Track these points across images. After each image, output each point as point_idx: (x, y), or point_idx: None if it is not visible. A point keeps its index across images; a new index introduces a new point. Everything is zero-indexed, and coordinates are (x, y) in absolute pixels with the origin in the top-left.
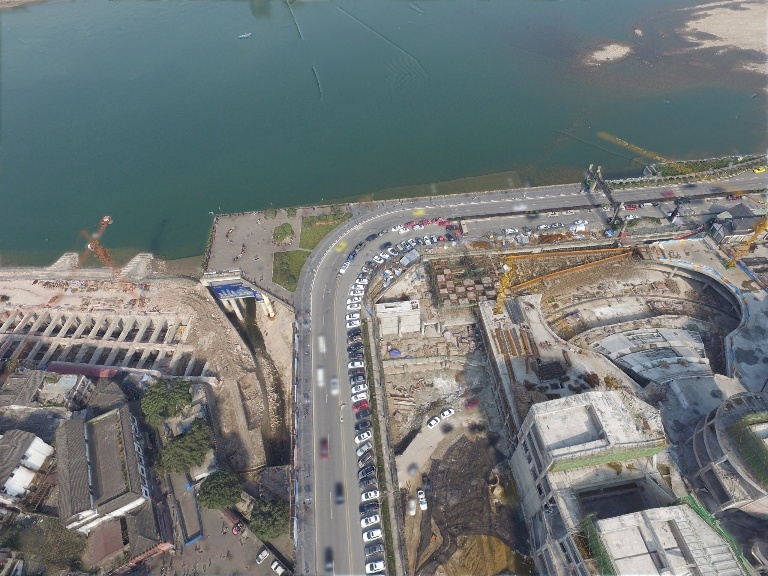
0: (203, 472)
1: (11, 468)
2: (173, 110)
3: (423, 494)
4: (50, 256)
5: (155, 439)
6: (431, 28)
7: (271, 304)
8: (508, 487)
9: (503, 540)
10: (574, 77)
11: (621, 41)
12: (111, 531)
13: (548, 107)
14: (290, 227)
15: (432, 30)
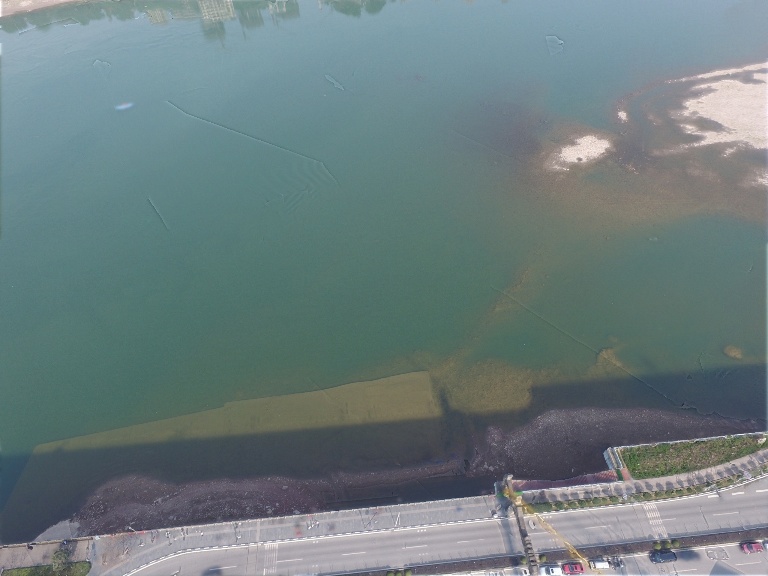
0: None
1: None
2: None
3: None
4: None
5: None
6: (361, 100)
7: None
8: None
9: None
10: (532, 190)
11: (599, 130)
12: None
13: (491, 243)
14: None
15: (362, 103)
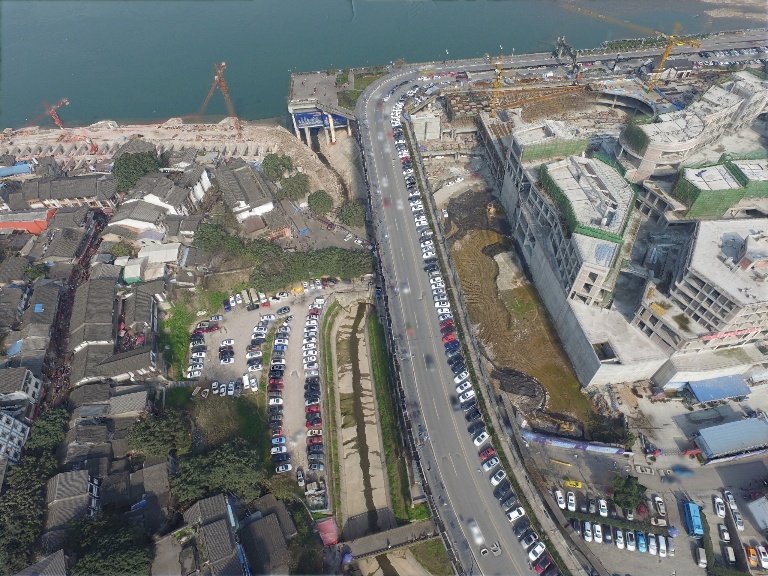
0: (305, 201)
1: (196, 180)
2: (232, 33)
3: (445, 210)
4: (160, 121)
5: (270, 190)
6: None
7: (334, 130)
8: (499, 210)
9: (496, 231)
10: (555, 6)
11: None
12: (256, 220)
13: (533, 26)
14: (347, 75)
15: None
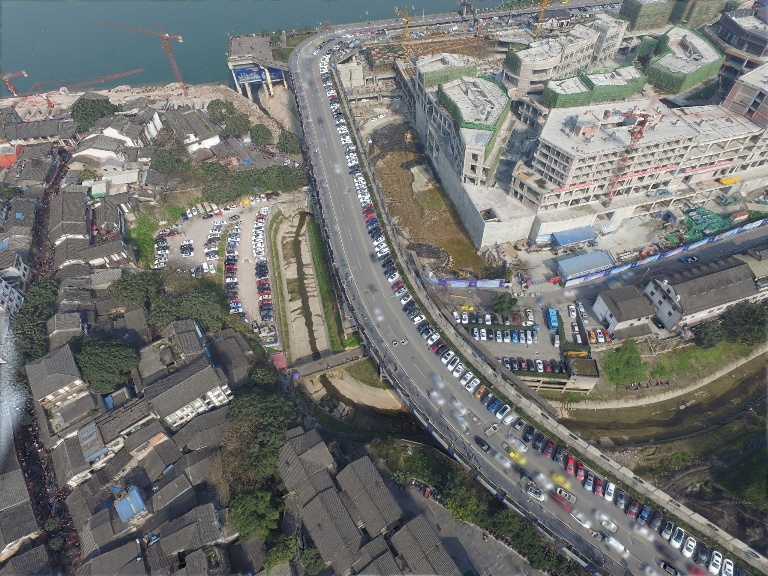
0: (248, 137)
1: (148, 119)
2: (172, 13)
3: None
4: None
5: None
6: None
7: (272, 84)
8: (415, 137)
9: (412, 152)
10: None
11: None
12: (205, 151)
13: None
14: None
15: None
